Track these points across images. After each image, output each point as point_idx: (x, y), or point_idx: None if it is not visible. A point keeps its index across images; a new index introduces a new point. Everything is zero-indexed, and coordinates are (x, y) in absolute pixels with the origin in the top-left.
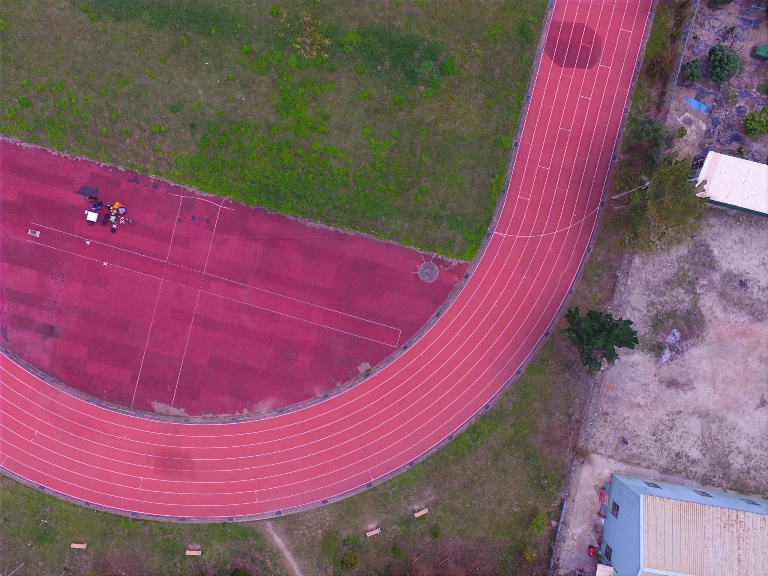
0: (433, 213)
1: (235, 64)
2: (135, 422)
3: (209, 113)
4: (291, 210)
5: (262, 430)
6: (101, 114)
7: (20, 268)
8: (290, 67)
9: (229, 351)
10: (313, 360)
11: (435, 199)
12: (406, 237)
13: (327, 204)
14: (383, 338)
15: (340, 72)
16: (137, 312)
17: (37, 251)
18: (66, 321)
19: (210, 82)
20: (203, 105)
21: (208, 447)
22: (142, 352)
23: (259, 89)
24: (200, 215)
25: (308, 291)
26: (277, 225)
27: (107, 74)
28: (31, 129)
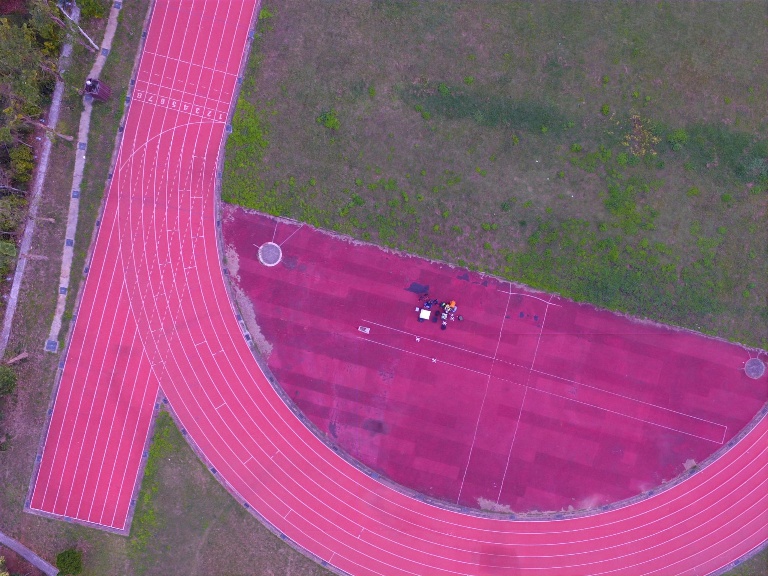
0: (760, 309)
1: (564, 162)
2: (461, 519)
3: (539, 210)
4: (619, 307)
5: (587, 527)
6: (433, 212)
7: (350, 365)
8: (619, 165)
9: (555, 448)
10: (639, 457)
11: (762, 295)
12: (732, 333)
13: (654, 301)
14: (709, 435)
15: (668, 169)
16: (464, 408)
17: (367, 348)
18: (394, 417)
19: (540, 180)
20: (533, 202)
21: (533, 544)
22: (469, 448)
23: (588, 186)
24: (528, 312)
25: (634, 387)
26: (604, 322)
27: (439, 172)
28: (364, 227)
